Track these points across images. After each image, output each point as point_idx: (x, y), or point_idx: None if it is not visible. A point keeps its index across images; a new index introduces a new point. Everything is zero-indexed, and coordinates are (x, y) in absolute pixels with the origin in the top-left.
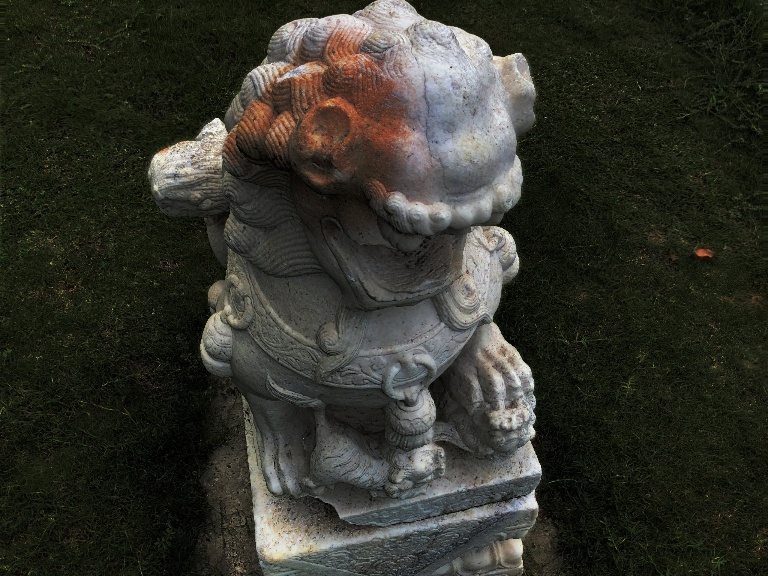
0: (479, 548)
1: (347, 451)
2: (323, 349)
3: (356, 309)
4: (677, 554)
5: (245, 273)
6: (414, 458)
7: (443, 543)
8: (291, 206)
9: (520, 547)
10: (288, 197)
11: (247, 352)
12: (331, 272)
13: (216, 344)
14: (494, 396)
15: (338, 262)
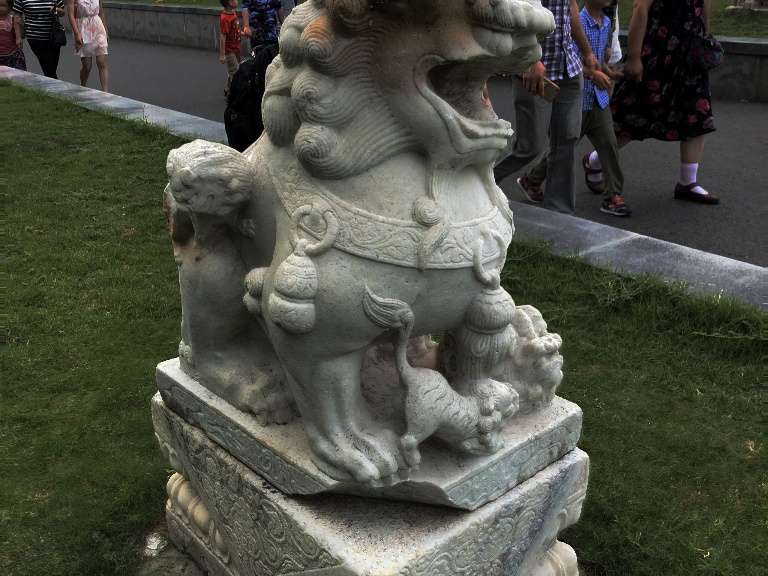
0: (540, 561)
1: (440, 382)
2: (424, 220)
3: (448, 164)
4: (686, 530)
5: (316, 195)
6: (494, 385)
7: (523, 531)
8: (369, 86)
9: (572, 549)
10: (366, 77)
11: (337, 271)
12: (427, 122)
13: (300, 277)
14: (527, 326)
15: (434, 106)
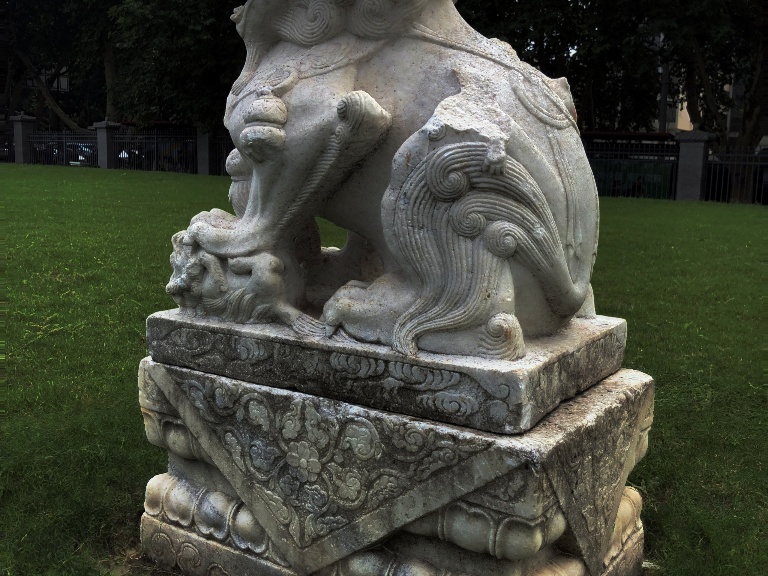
0: None
1: None
2: None
3: None
4: None
5: None
6: None
7: None
8: None
9: None
10: None
11: None
12: None
13: None
14: None
15: None
